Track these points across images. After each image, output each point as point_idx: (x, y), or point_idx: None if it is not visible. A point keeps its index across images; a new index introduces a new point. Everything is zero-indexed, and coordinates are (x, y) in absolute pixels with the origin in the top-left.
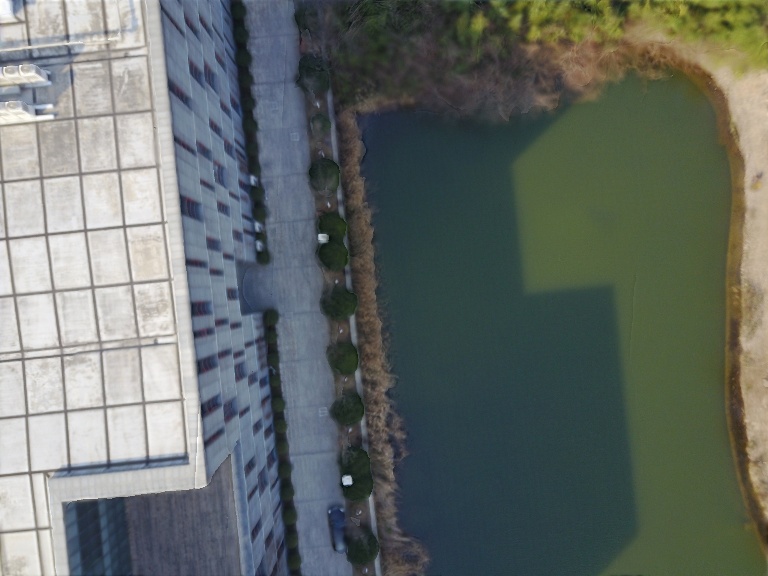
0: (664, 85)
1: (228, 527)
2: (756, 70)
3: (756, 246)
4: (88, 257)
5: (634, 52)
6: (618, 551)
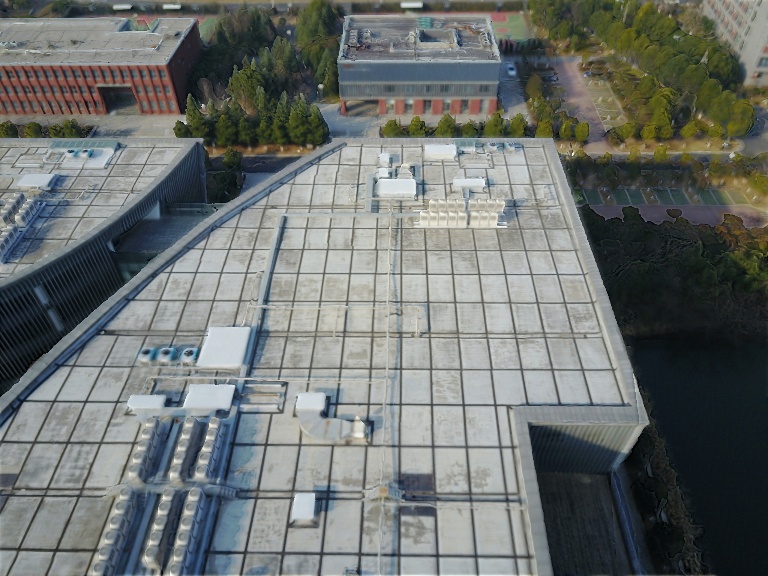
0: None
1: (616, 553)
2: None
3: None
4: (534, 287)
5: None
6: None
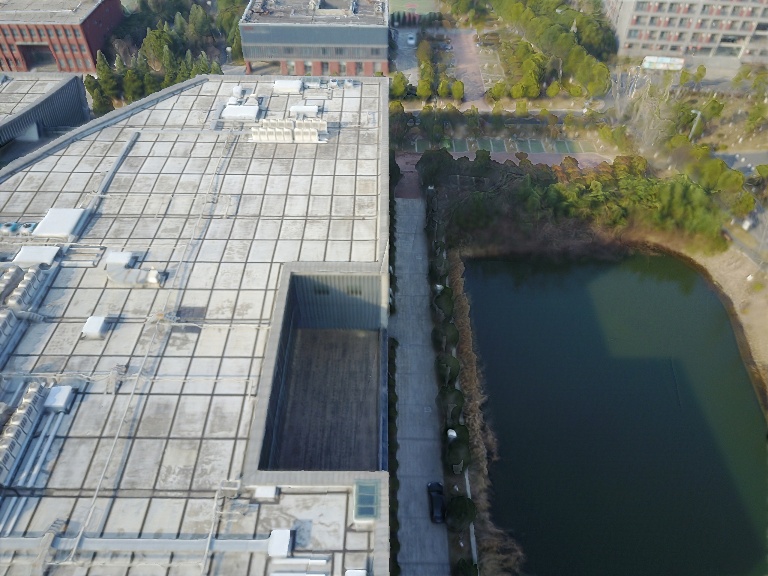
0: (661, 262)
1: (370, 383)
2: (718, 249)
3: (758, 342)
4: (333, 184)
5: (636, 243)
6: (718, 574)
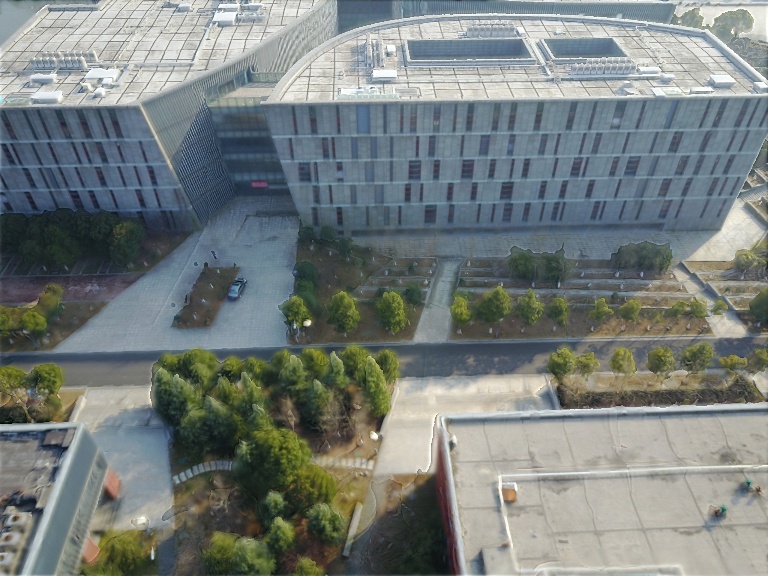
0: None
1: None
2: None
3: None
4: None
5: None
6: None
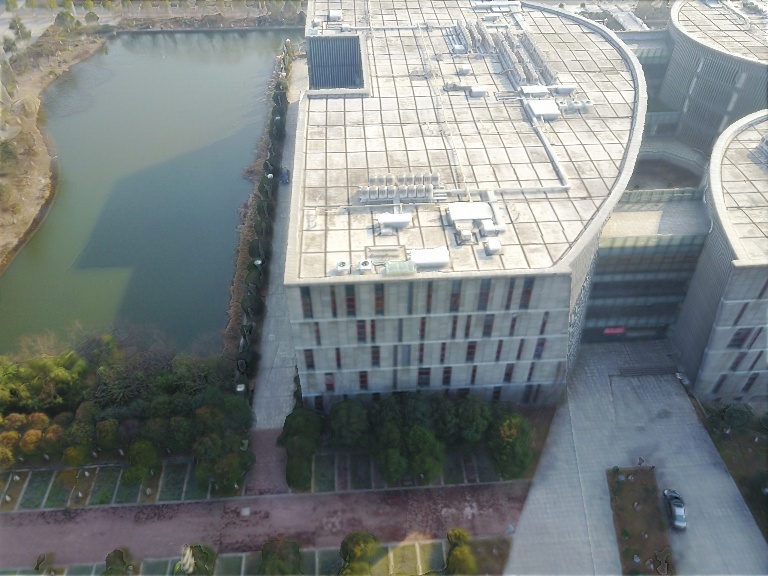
0: None
1: None
2: None
3: None
4: None
5: None
6: None
